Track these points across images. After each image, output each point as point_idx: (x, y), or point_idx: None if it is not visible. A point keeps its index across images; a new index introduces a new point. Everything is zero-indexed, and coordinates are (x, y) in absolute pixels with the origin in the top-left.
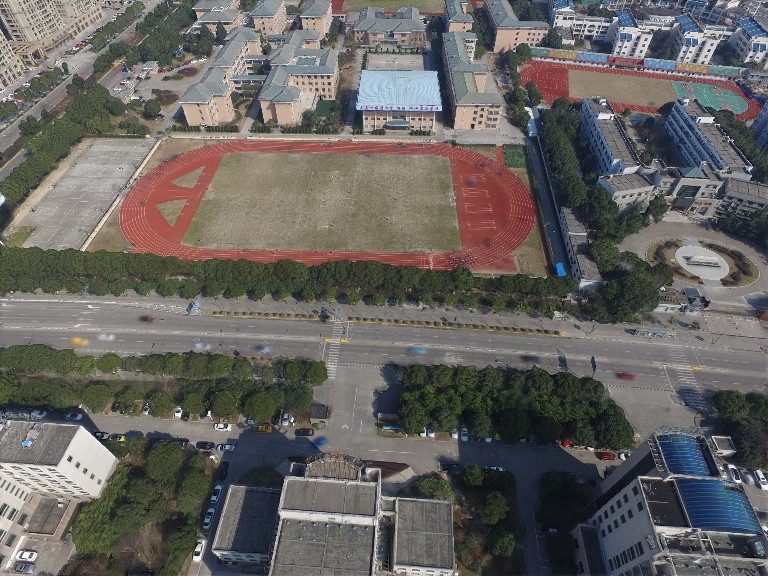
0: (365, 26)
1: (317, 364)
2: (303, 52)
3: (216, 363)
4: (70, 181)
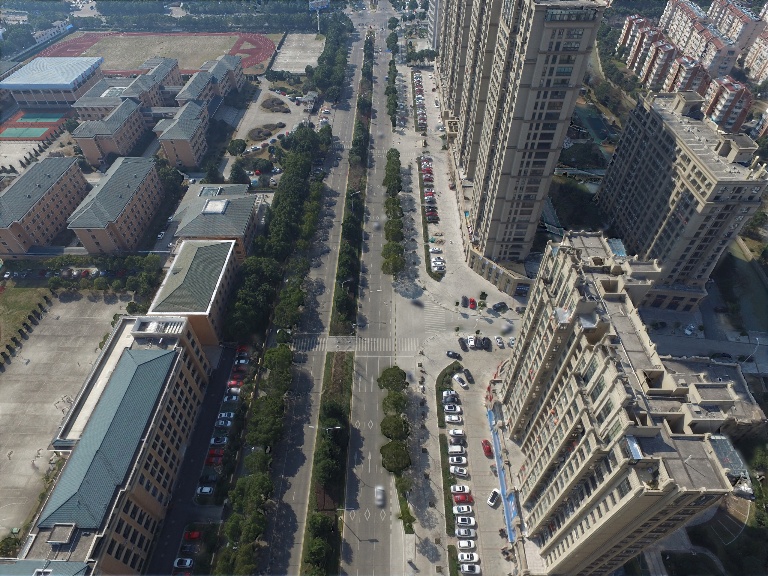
0: None
1: (183, 4)
2: None
3: (216, 3)
4: (313, 54)
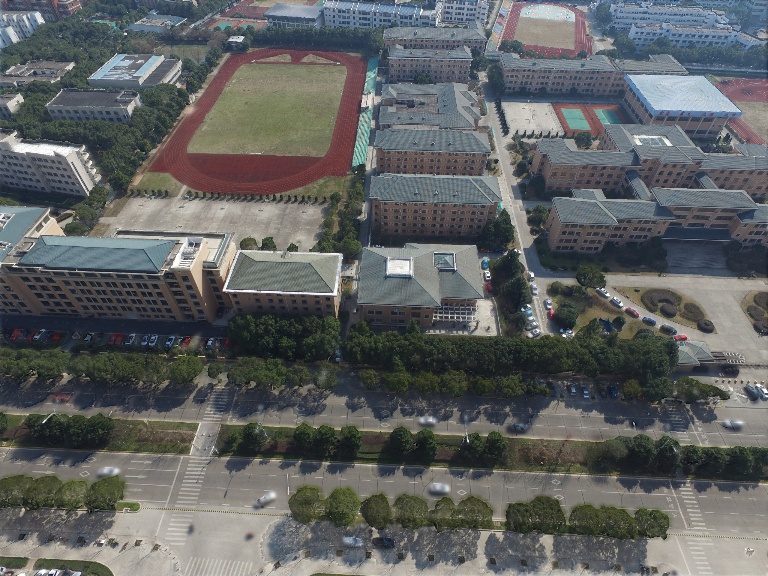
0: (469, 117)
1: None
2: (635, 144)
3: None
4: None
